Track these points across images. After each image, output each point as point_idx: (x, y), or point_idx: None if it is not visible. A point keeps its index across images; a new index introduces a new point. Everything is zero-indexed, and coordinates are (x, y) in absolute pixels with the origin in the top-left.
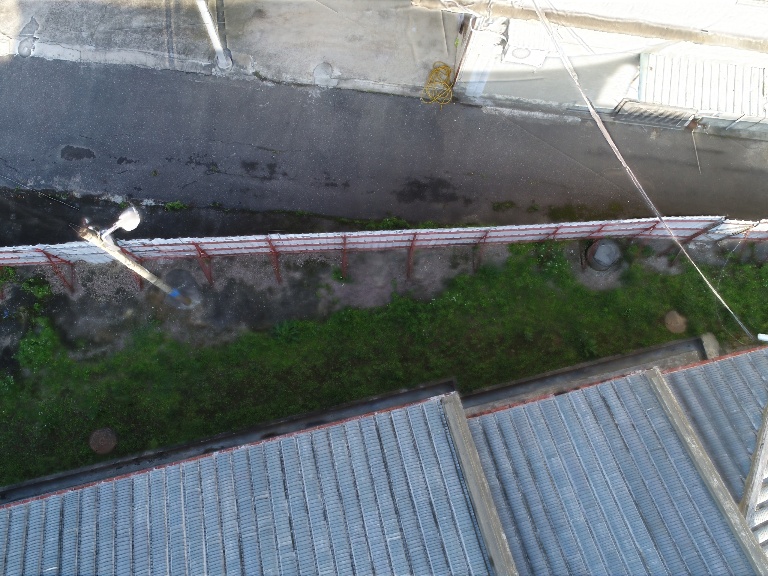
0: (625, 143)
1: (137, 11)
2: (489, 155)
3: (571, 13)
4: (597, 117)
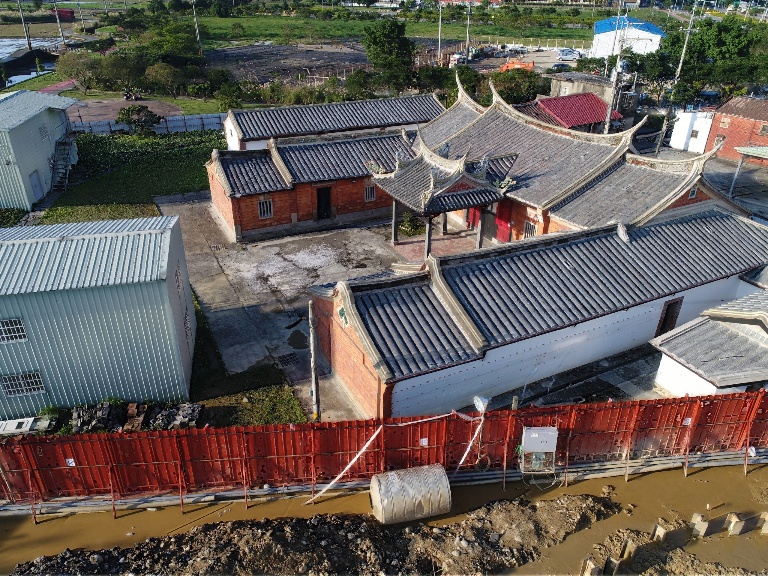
0: None
1: (722, 185)
2: None
3: None
4: None
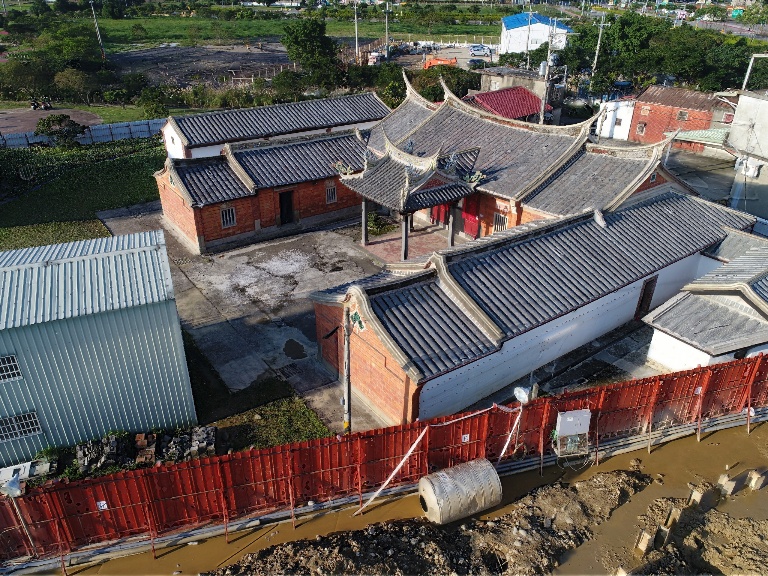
0: None
1: None
2: None
3: (767, 158)
4: None
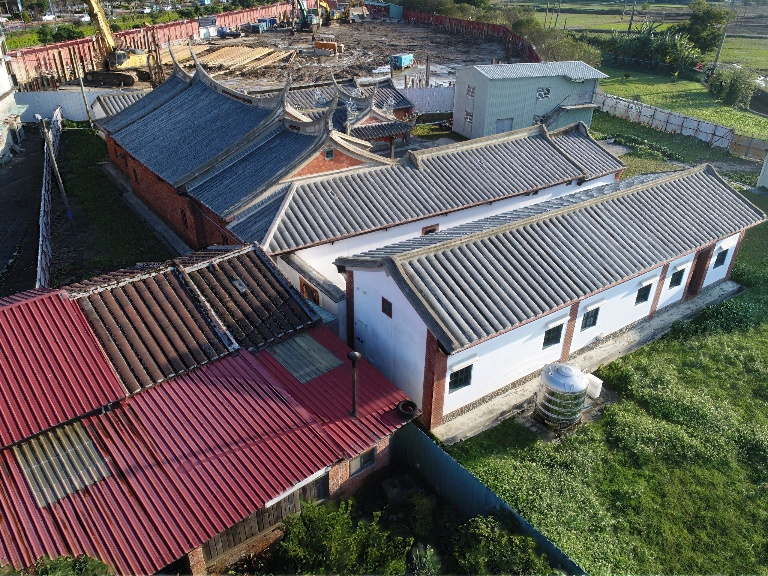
0: (6, 176)
1: None
2: (5, 195)
3: None
4: (5, 120)
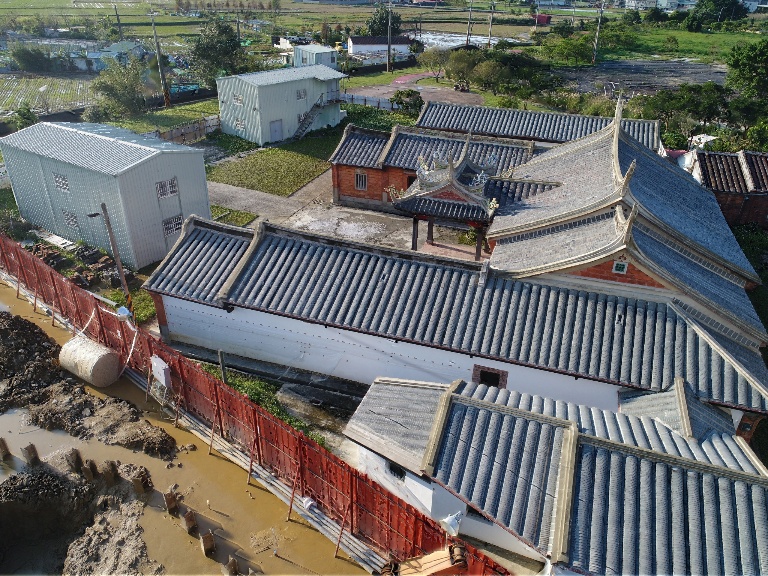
0: None
1: None
2: None
3: None
4: None
